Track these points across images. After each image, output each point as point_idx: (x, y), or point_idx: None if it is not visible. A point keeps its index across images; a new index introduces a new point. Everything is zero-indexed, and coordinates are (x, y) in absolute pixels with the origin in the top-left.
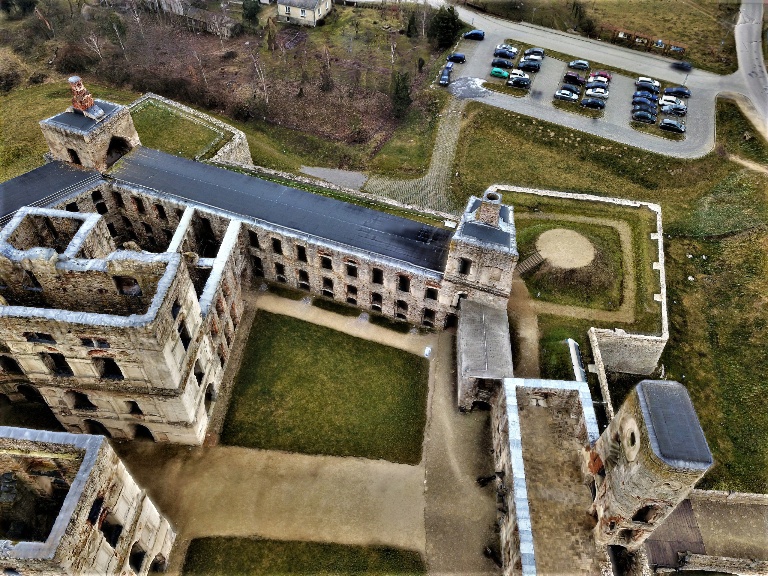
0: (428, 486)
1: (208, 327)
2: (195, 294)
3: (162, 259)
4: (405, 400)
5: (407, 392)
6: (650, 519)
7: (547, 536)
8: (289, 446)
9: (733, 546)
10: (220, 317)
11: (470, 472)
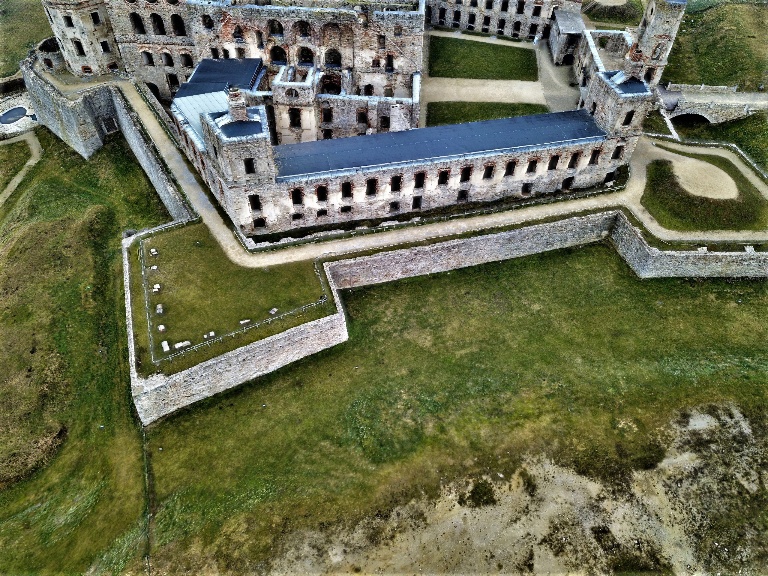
0: (544, 87)
1: None
2: None
3: None
4: (525, 62)
5: (525, 60)
6: (660, 56)
7: None
8: (467, 77)
9: None
10: None
11: (565, 83)
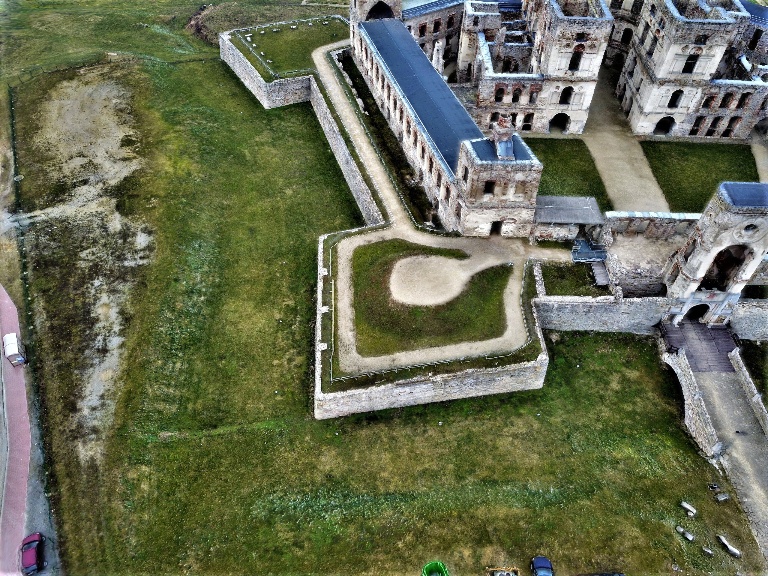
0: None
1: (708, 92)
2: (721, 57)
3: (728, 18)
4: None
5: None
6: None
7: (654, 249)
8: (654, 166)
9: (707, 392)
10: (723, 108)
11: None
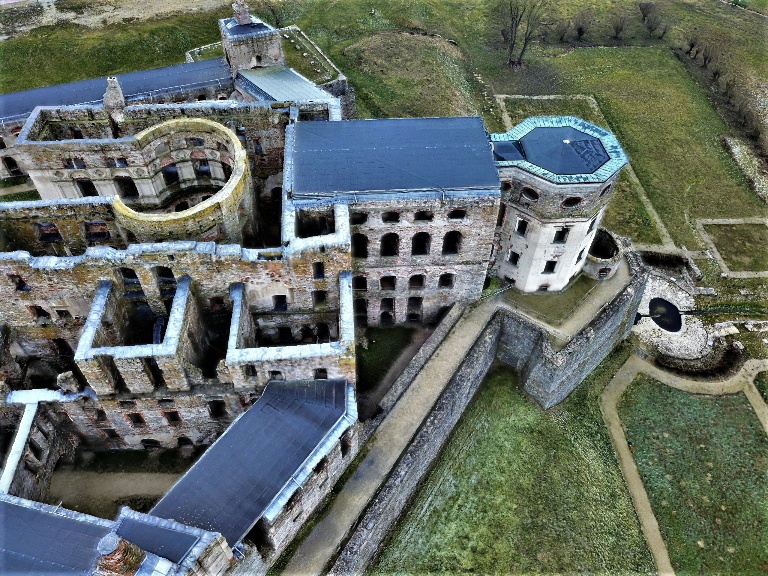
0: None
1: None
2: None
3: None
4: None
5: None
6: None
7: None
8: None
9: None
10: None
11: None
